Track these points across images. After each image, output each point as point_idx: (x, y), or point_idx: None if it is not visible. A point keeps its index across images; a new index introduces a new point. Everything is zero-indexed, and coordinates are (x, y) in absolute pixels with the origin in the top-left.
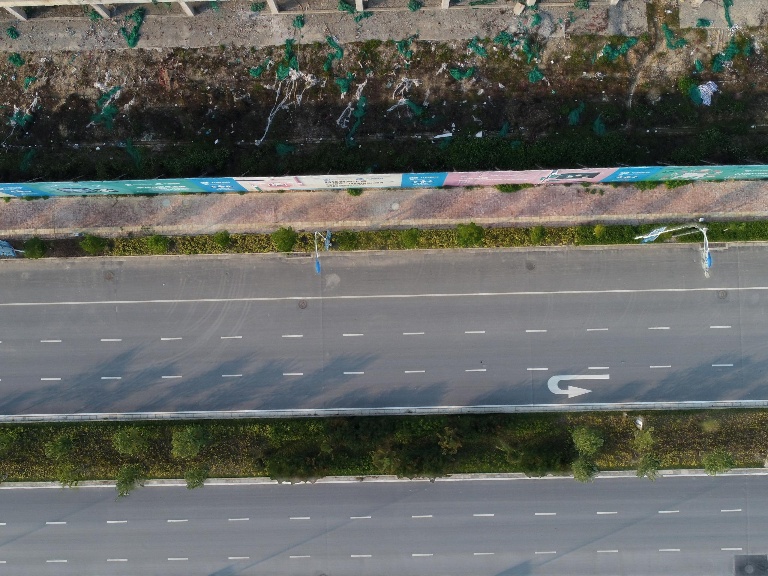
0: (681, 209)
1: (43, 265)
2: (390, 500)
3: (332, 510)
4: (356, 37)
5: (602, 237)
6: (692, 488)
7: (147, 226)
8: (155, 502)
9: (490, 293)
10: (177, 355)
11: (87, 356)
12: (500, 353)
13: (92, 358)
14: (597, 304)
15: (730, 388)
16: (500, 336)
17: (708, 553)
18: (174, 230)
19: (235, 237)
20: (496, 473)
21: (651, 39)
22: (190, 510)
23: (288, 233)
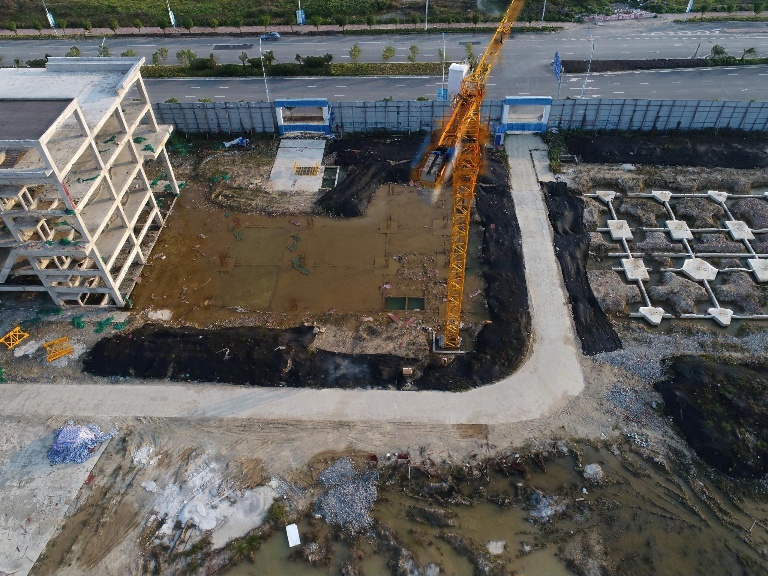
0: None
1: None
2: (11, 63)
3: None
4: None
5: None
6: None
7: None
8: None
9: None
10: None
11: None
12: None
13: None
14: None
15: None
16: None
17: None
18: None
19: None
20: None
21: None
22: None
23: None
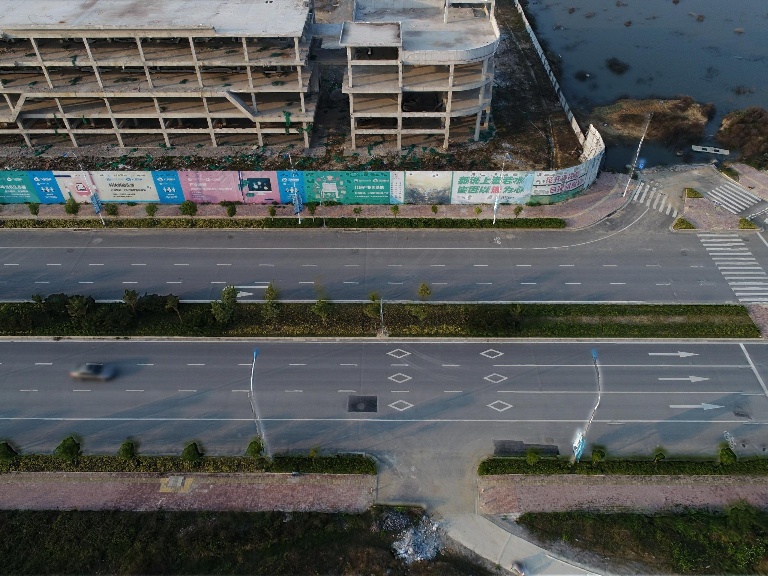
0: (332, 215)
1: None
2: (74, 353)
3: (23, 359)
4: (163, 155)
5: (278, 222)
6: (319, 350)
7: None
8: None
9: (199, 248)
10: None
11: None
12: (195, 275)
13: None
14: (270, 254)
15: (355, 294)
16: (198, 267)
17: (326, 394)
18: (9, 218)
19: (45, 220)
20: (165, 337)
21: (326, 159)
22: None
23: (74, 201)
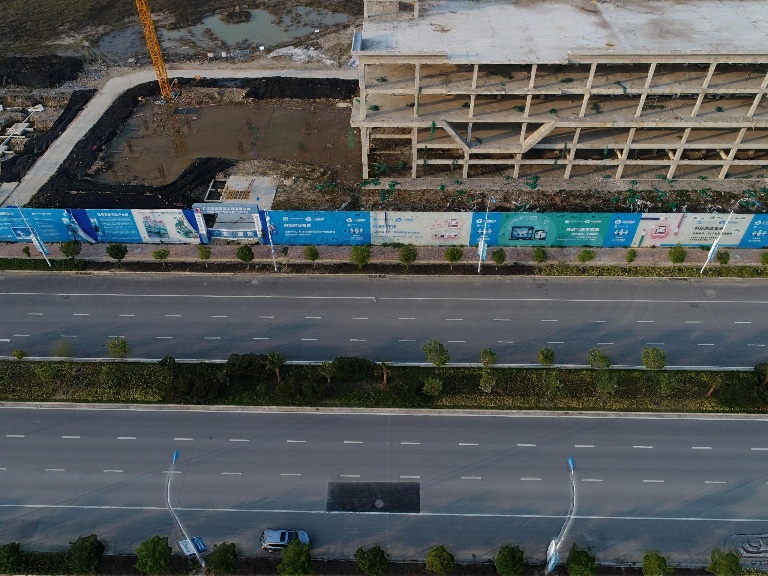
0: None
1: (489, 280)
2: None
3: None
4: (672, 188)
5: None
6: None
7: (563, 262)
8: (617, 431)
9: None
10: (605, 331)
11: (533, 329)
12: None
13: (537, 330)
14: None
15: None
16: None
17: None
18: (583, 264)
19: (629, 267)
20: None
21: None
22: (652, 438)
23: None
